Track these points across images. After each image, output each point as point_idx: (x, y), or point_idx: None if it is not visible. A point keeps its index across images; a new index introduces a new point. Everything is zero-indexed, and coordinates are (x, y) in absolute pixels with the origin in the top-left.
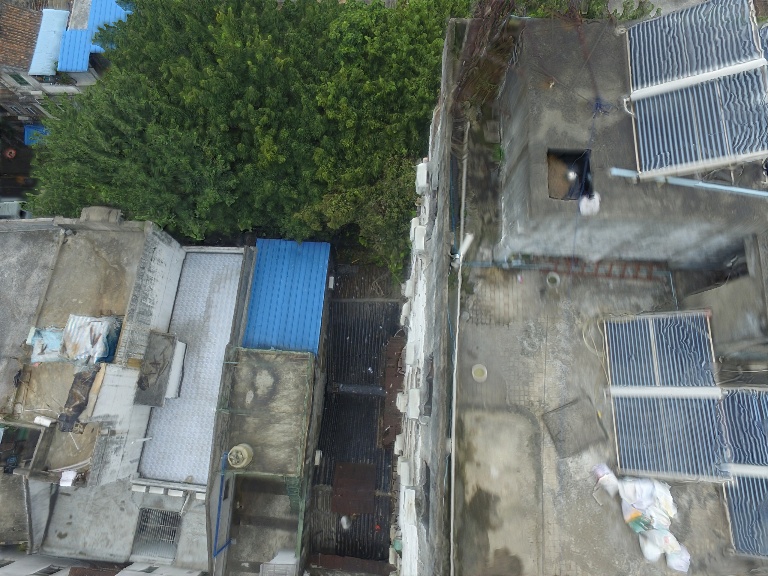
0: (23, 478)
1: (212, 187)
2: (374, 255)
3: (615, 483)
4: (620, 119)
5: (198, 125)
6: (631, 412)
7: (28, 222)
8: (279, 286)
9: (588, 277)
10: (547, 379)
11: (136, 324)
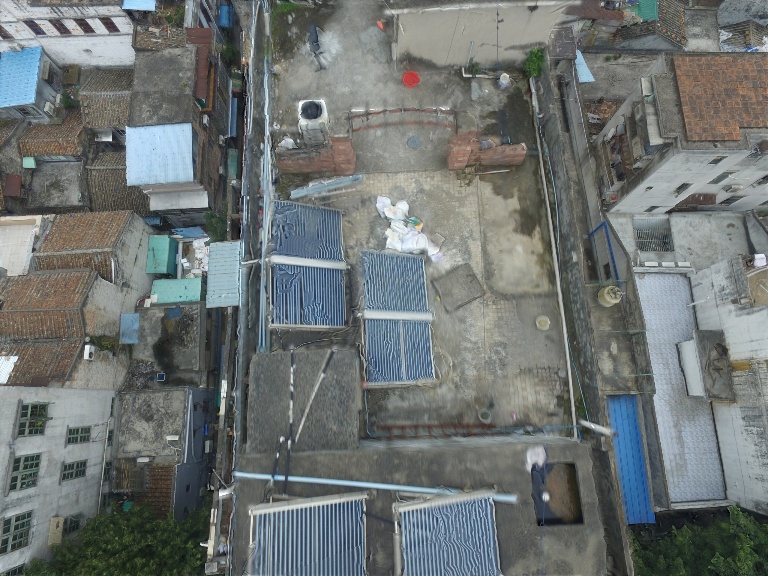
0: None
1: None
2: None
3: (430, 248)
4: (510, 570)
5: None
6: (418, 301)
7: None
8: (616, 466)
9: (449, 424)
10: (482, 324)
11: (759, 404)
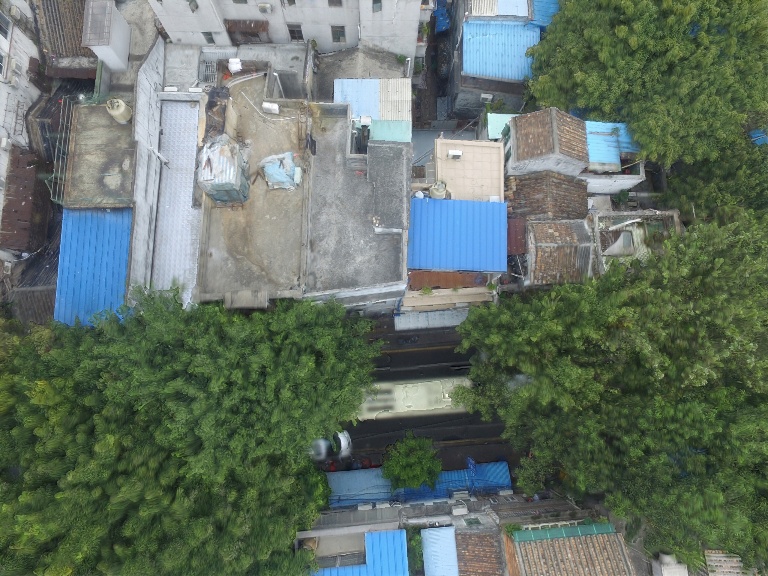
0: (307, 78)
1: (117, 344)
2: (13, 323)
3: None
4: None
5: (140, 426)
6: None
7: (333, 290)
8: (107, 274)
9: None
10: None
11: None
